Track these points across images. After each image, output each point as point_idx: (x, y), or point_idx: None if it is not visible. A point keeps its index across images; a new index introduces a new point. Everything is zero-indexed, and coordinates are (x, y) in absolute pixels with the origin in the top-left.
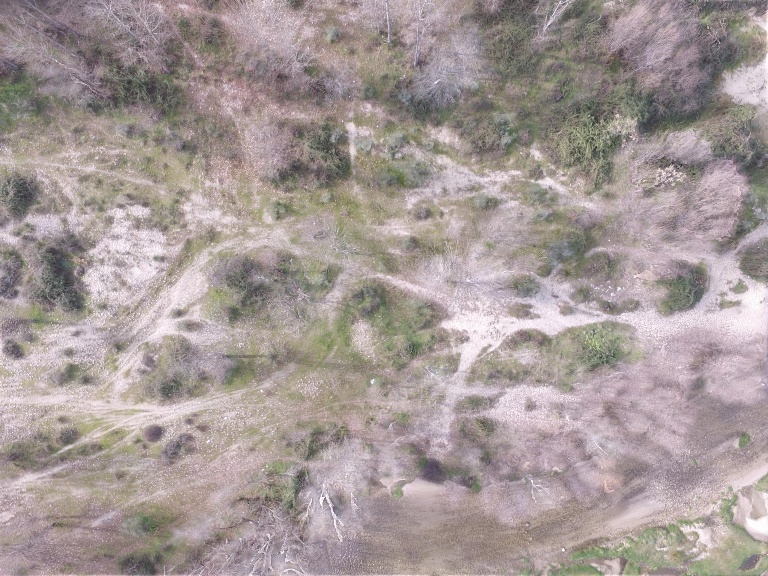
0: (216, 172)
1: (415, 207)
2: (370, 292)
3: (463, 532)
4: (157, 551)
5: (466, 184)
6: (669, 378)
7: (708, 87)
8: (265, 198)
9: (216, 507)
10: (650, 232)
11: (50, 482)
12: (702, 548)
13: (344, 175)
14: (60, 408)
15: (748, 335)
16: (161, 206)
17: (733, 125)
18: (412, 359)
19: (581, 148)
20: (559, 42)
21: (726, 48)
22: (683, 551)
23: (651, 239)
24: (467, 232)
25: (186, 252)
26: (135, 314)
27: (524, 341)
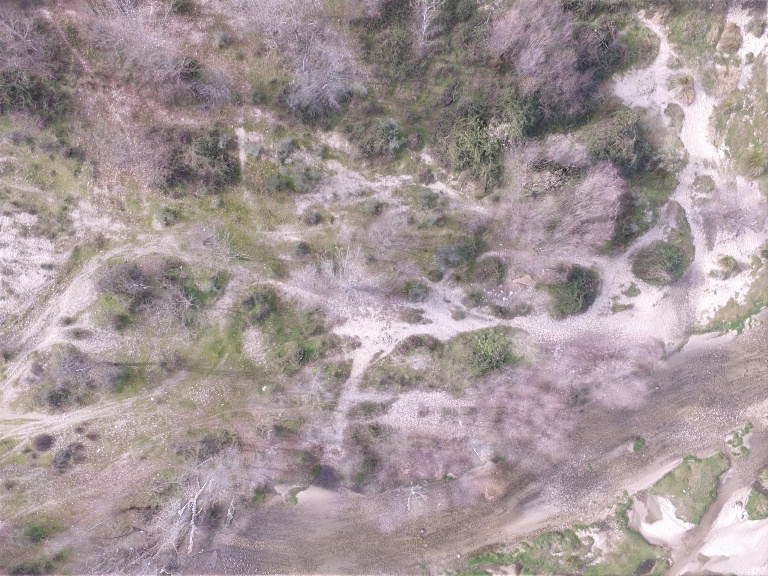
0: (105, 179)
1: (306, 213)
2: (259, 298)
3: (358, 539)
4: (47, 561)
5: (357, 189)
6: (563, 382)
7: (591, 90)
8: (154, 205)
9: (107, 516)
10: (541, 236)
11: None
12: (597, 553)
13: (233, 181)
14: None
15: (641, 338)
16: (49, 213)
17: (619, 128)
18: (304, 365)
19: (470, 152)
20: (448, 46)
21: (614, 51)
22: (578, 556)
23: (542, 243)
24: (358, 237)
25: (74, 260)
26: (24, 323)
27: (416, 346)
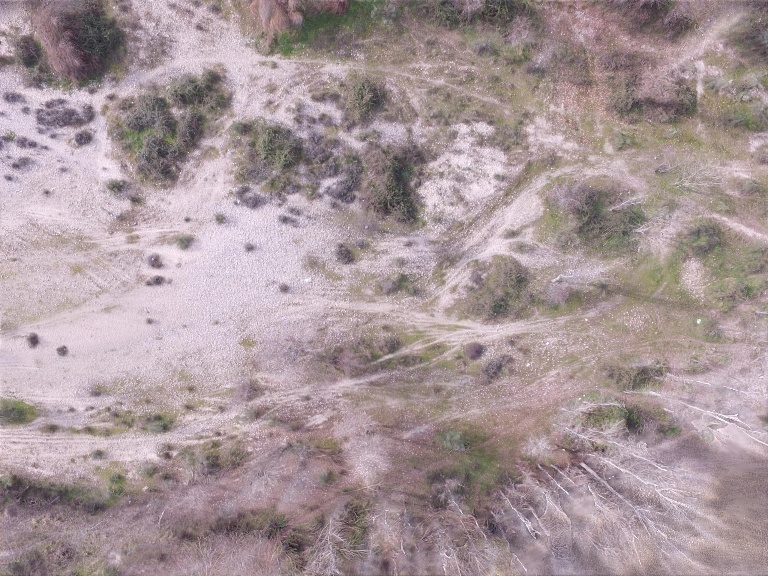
0: (561, 97)
1: (758, 151)
2: (709, 231)
3: None
4: (467, 469)
5: None
6: None
7: None
8: (608, 128)
9: (529, 431)
10: None
11: (367, 389)
12: None
13: (691, 112)
14: (384, 317)
15: None
16: (505, 125)
17: None
18: (740, 303)
19: None
20: None
21: None
22: None
23: None
24: None
25: (526, 174)
26: (468, 230)
27: None
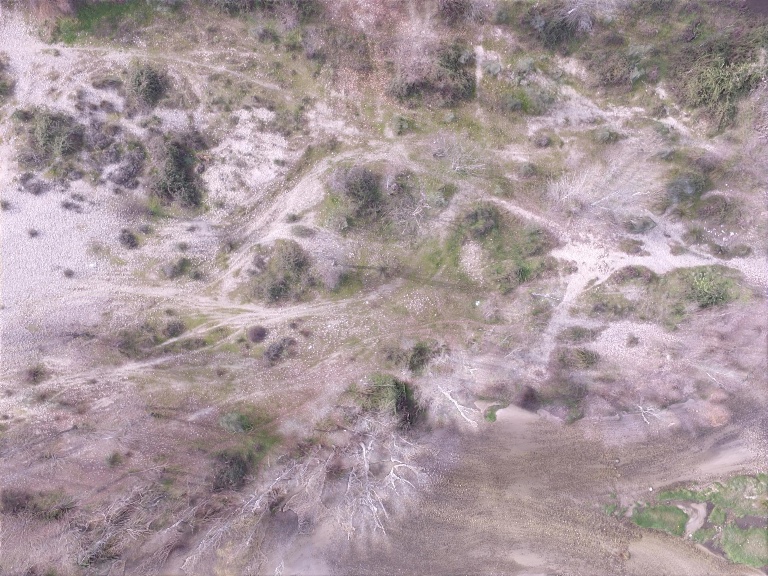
0: (342, 83)
1: (536, 135)
2: (485, 214)
3: (552, 462)
4: (250, 450)
5: (588, 116)
6: None
7: None
8: (388, 113)
9: (312, 413)
10: None
11: (152, 372)
12: None
13: (469, 97)
14: (168, 301)
15: None
16: (286, 111)
17: None
18: (519, 285)
19: (709, 89)
20: None
21: None
22: None
23: None
24: (585, 164)
25: (306, 159)
26: (250, 215)
27: (632, 277)
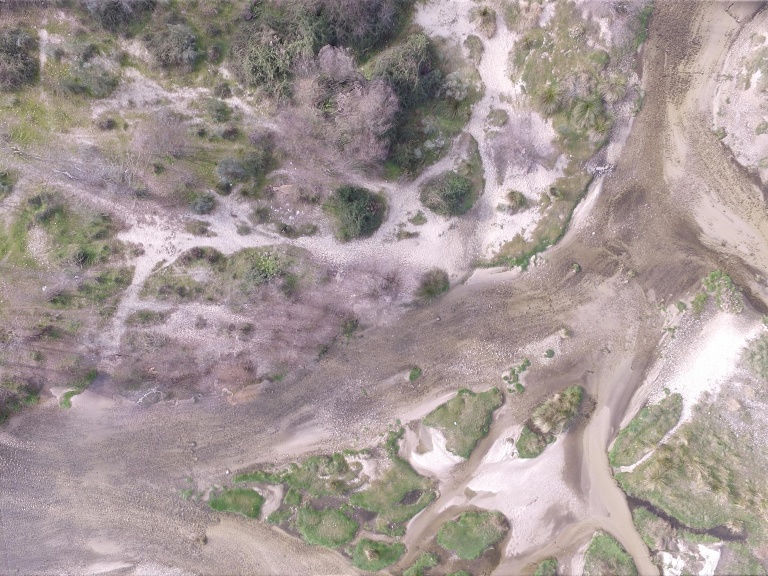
0: None
1: (100, 117)
2: (44, 198)
3: (130, 447)
4: None
5: (153, 98)
6: (343, 306)
7: (376, 10)
8: None
9: None
10: (332, 157)
11: None
12: (364, 479)
13: (30, 80)
14: None
15: (424, 267)
16: None
17: (407, 52)
18: (86, 269)
19: (263, 67)
20: None
21: None
22: (345, 481)
23: (331, 164)
24: (149, 145)
25: None
26: None
27: (198, 258)
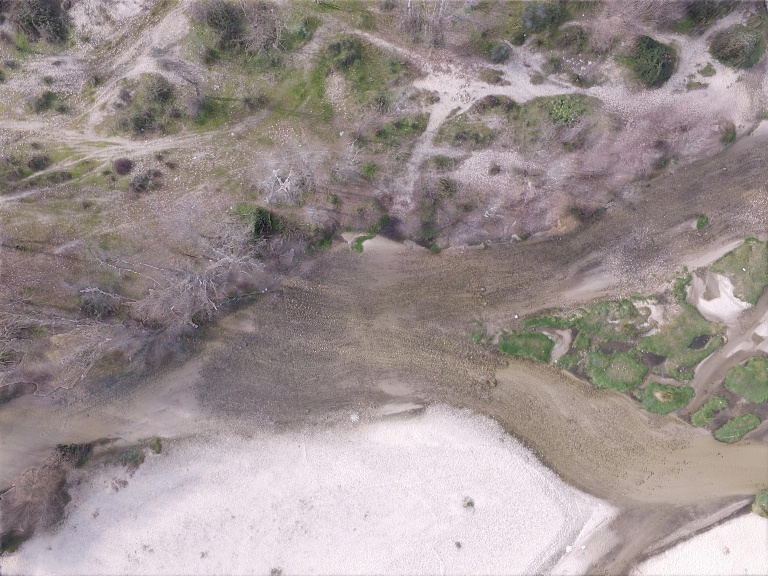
0: None
1: None
2: (346, 44)
3: (419, 292)
4: (116, 282)
5: None
6: (632, 154)
7: None
8: None
9: (178, 244)
10: (624, 10)
11: (18, 206)
12: (653, 323)
13: None
14: (35, 134)
15: (713, 118)
16: None
17: None
18: (382, 115)
19: None
20: None
21: None
22: (634, 325)
23: (624, 16)
24: None
25: None
26: (116, 49)
27: (493, 106)
